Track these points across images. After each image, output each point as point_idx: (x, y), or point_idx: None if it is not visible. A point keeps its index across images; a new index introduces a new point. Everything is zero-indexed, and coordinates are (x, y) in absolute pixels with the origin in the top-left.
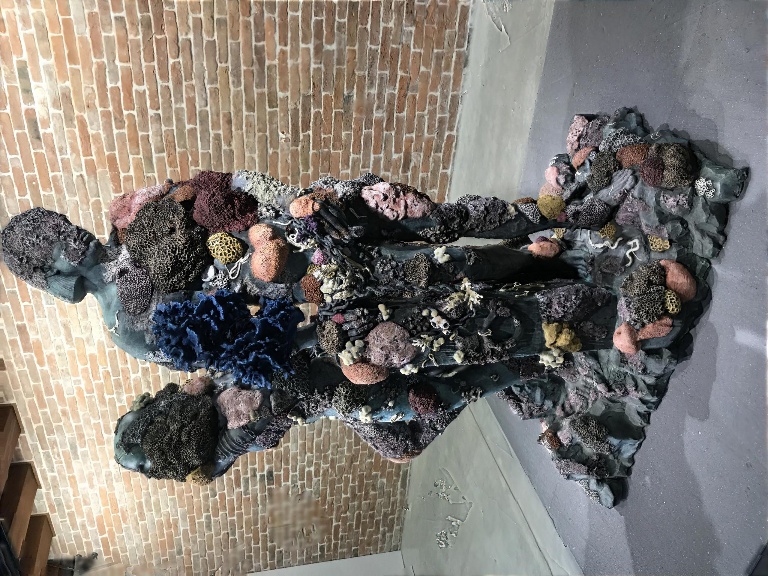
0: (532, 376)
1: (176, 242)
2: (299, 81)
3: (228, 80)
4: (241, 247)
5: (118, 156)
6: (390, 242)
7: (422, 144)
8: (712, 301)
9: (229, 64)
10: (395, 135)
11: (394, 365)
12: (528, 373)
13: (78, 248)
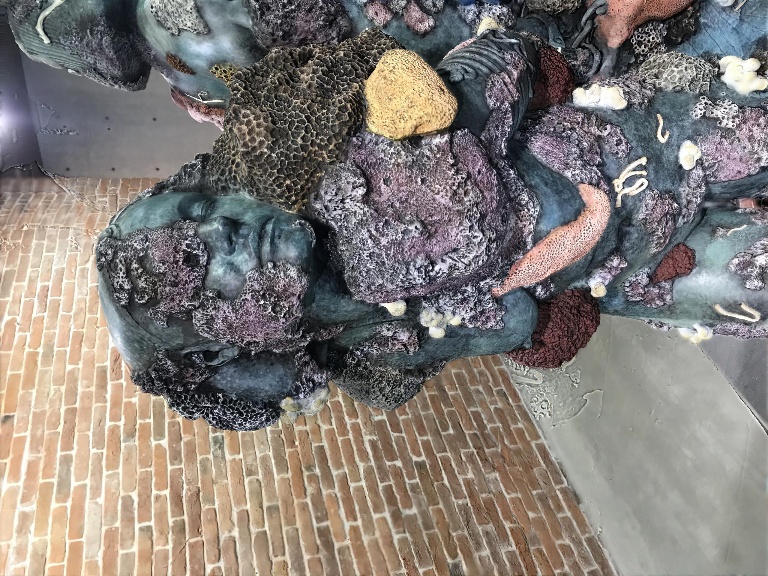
0: None
1: None
2: (384, 560)
3: None
4: None
5: None
6: None
7: None
8: None
9: (287, 559)
10: None
11: None
12: None
13: None
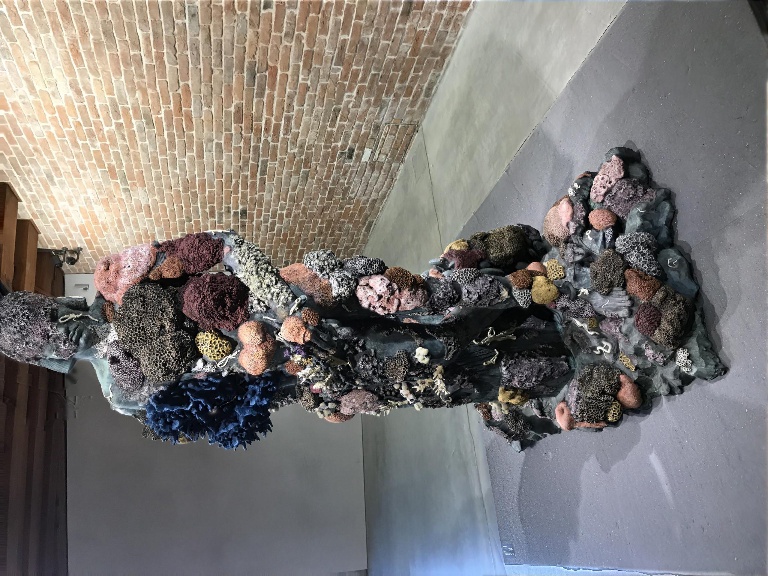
0: None
1: (166, 355)
2: None
3: None
4: (230, 346)
5: None
6: (376, 330)
7: None
8: (649, 416)
9: None
10: None
11: None
12: None
13: (69, 349)
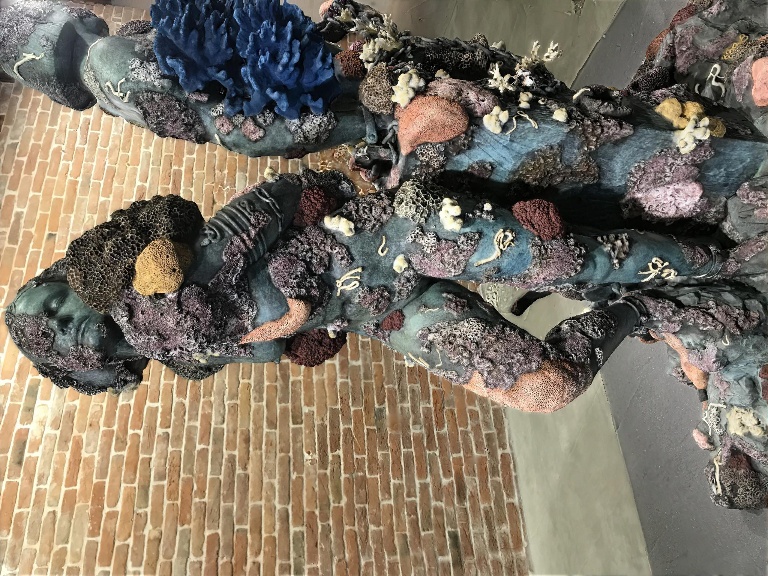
0: (697, 252)
1: None
2: (325, 396)
3: (249, 396)
4: None
5: (108, 485)
6: None
7: (474, 467)
8: None
9: (252, 382)
10: (440, 457)
11: (472, 106)
12: (687, 244)
13: None
